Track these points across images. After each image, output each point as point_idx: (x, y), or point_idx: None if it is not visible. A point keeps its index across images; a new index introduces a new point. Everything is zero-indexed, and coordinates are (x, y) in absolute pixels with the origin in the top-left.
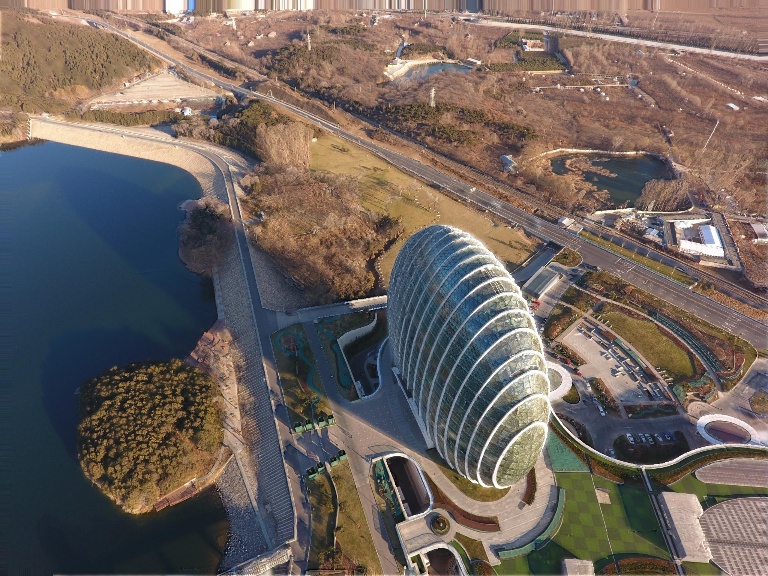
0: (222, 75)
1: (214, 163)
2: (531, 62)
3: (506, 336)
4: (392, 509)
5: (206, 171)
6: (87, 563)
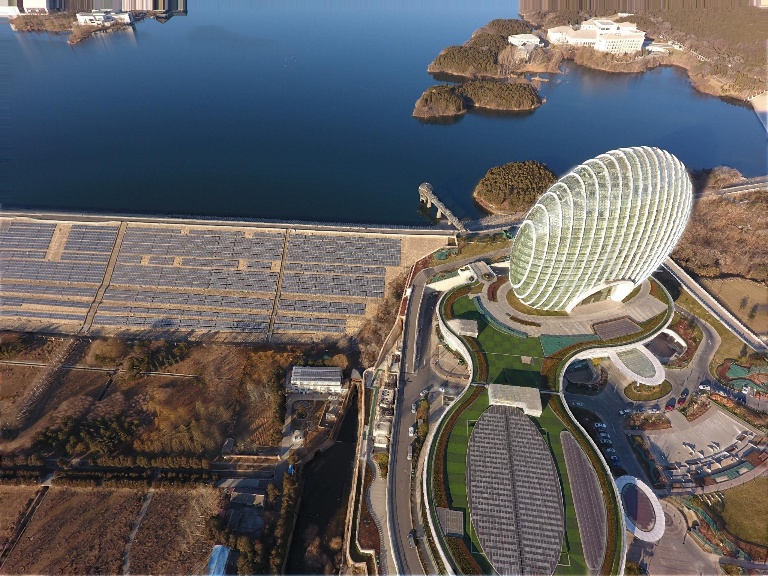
0: None
1: None
2: None
3: None
4: None
5: None
6: (451, 188)
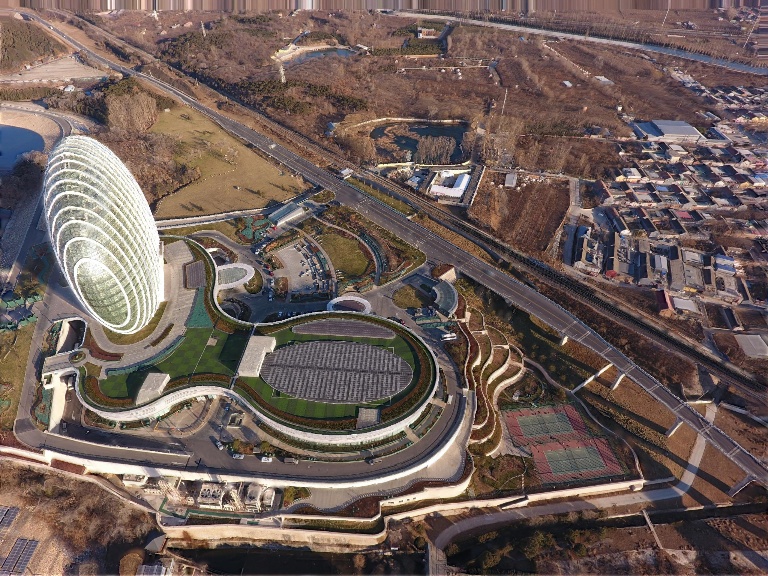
0: (120, 59)
1: (61, 127)
2: (414, 48)
3: (59, 196)
4: (50, 350)
5: (53, 134)
6: None
